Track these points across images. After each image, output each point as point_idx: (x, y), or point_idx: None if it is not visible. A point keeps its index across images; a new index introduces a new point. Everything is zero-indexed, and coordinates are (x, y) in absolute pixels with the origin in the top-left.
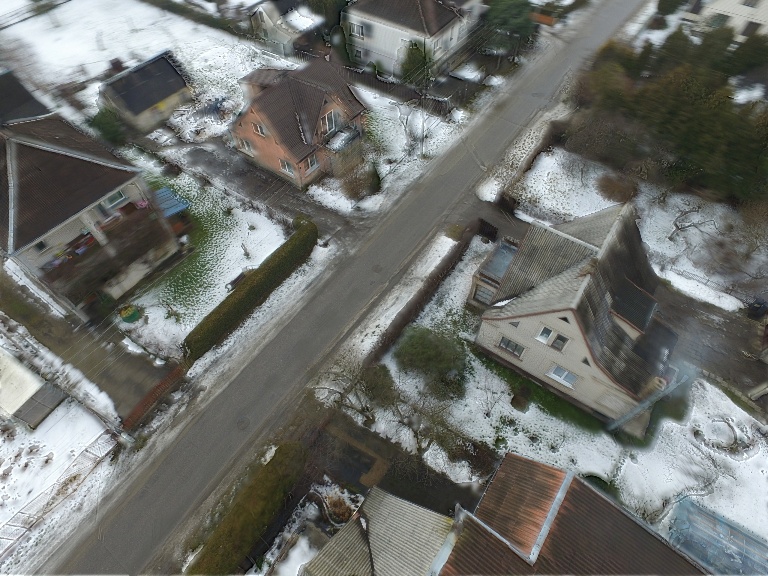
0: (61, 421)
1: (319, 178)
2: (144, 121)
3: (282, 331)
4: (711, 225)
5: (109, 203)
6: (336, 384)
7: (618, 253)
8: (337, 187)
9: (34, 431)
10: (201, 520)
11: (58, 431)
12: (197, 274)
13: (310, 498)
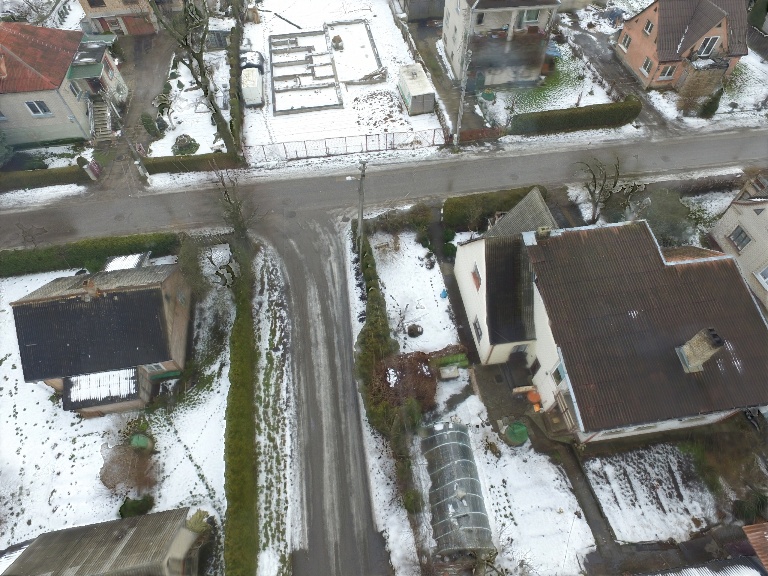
0: (424, 120)
1: (666, 89)
2: (565, 2)
3: (570, 152)
4: None
5: (527, 19)
6: (585, 193)
7: None
8: (676, 100)
9: (409, 117)
10: None
11: (420, 123)
12: (538, 98)
13: None
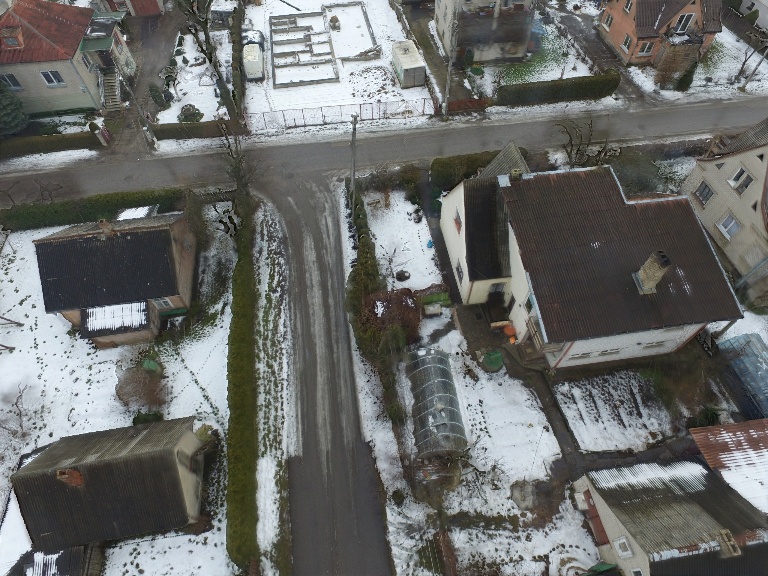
0: (415, 93)
1: (645, 65)
2: None
3: (552, 121)
4: None
5: None
6: (564, 157)
7: None
8: (654, 75)
9: (402, 90)
10: None
11: (412, 95)
12: (524, 73)
13: None
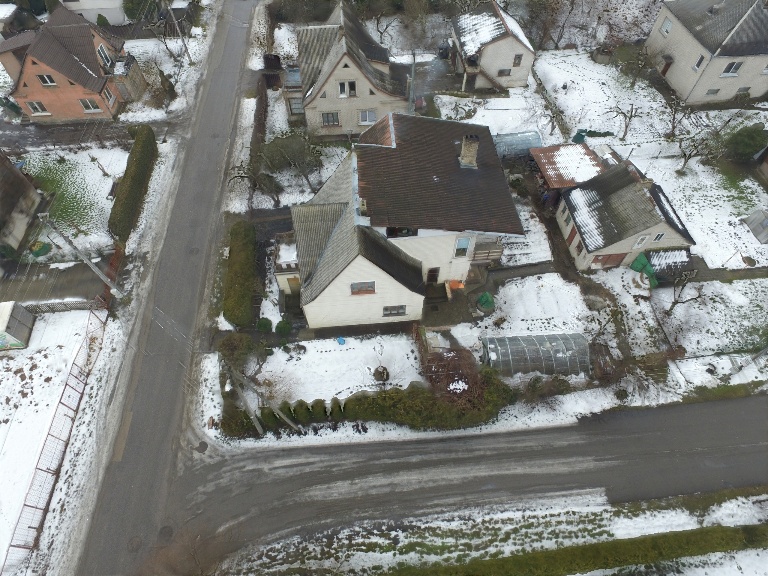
0: (46, 330)
1: (122, 107)
2: None
3: (177, 198)
4: (396, 21)
5: None
6: (240, 200)
7: (352, 29)
8: (142, 106)
9: (28, 348)
10: (210, 303)
11: (50, 336)
12: (74, 204)
13: (271, 254)
